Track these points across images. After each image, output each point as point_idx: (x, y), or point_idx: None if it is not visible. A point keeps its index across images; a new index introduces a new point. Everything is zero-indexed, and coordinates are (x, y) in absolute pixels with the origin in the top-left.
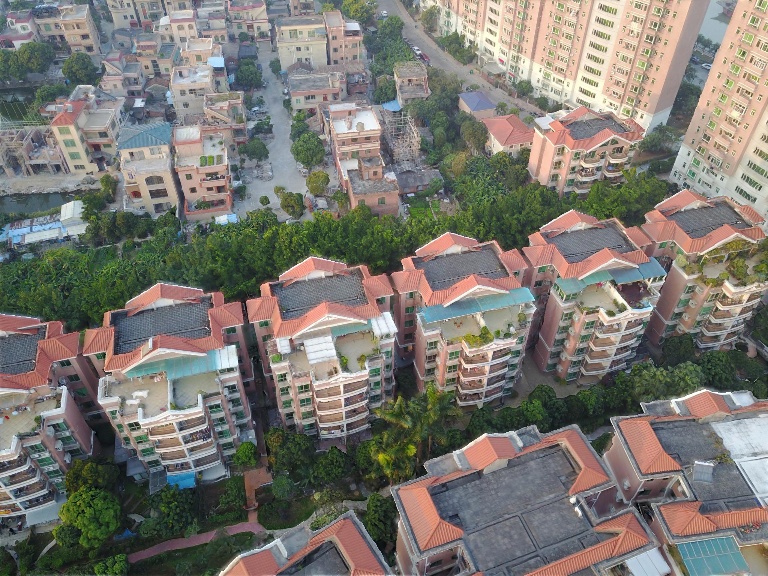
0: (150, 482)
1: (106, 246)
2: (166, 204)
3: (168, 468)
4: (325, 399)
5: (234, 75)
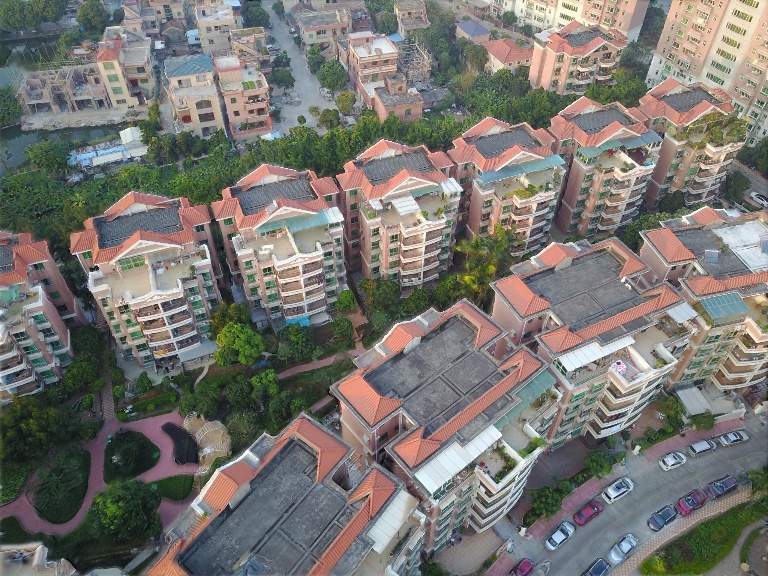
0: (273, 325)
1: (167, 165)
2: (212, 128)
3: (286, 313)
4: (411, 246)
5: (242, 17)
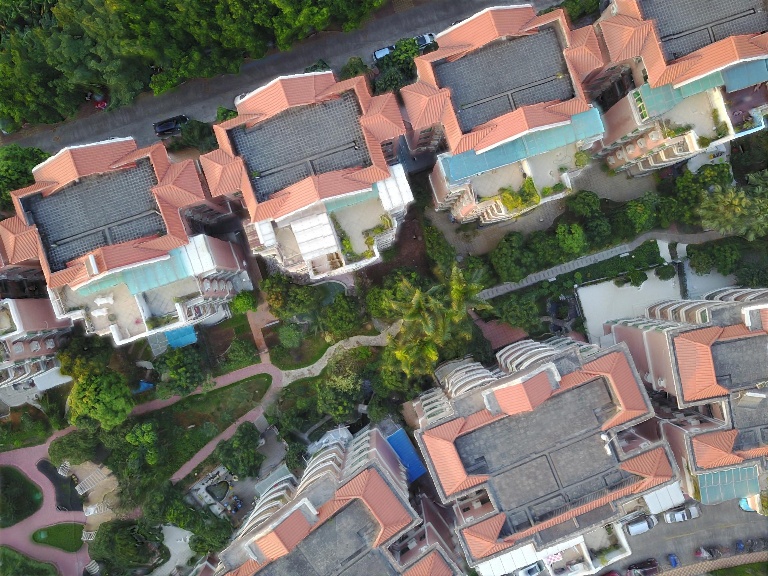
0: (148, 339)
1: None
2: None
3: None
4: None
5: None
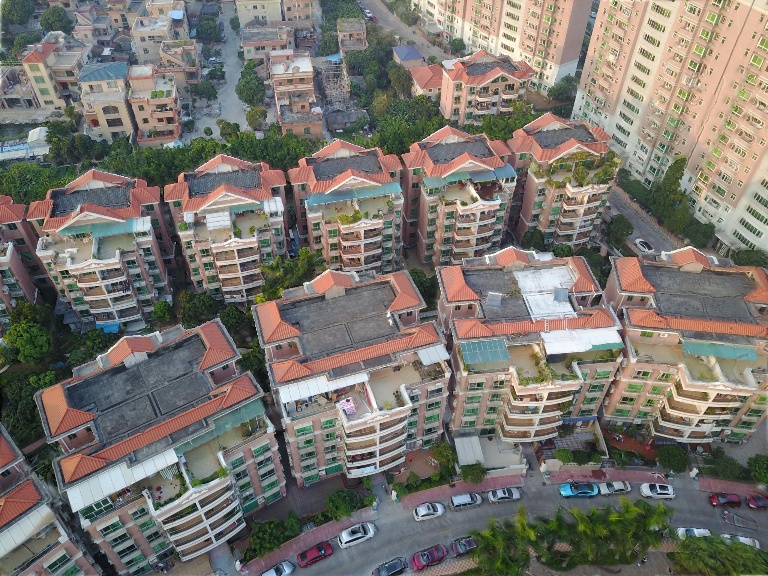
0: (82, 328)
1: (67, 165)
2: (122, 133)
3: (97, 318)
4: (223, 262)
5: (196, 30)
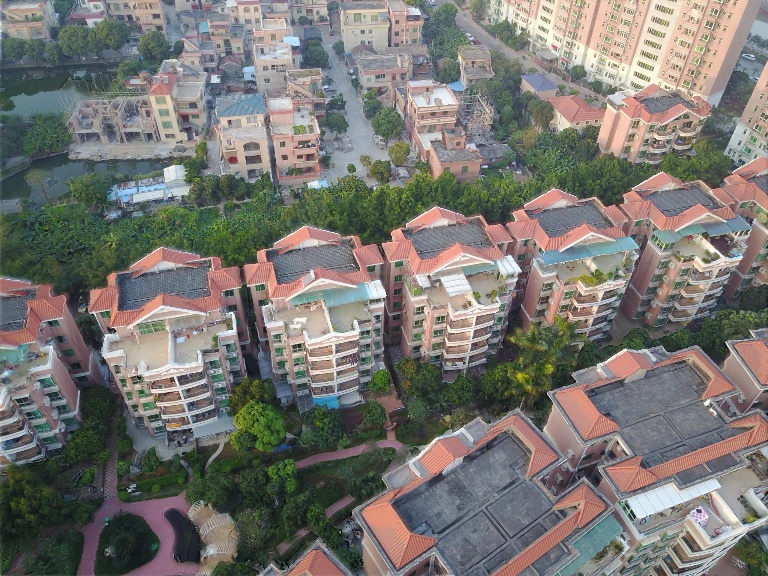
0: (298, 403)
1: (208, 207)
2: (259, 170)
3: (314, 391)
4: (458, 330)
5: (301, 55)
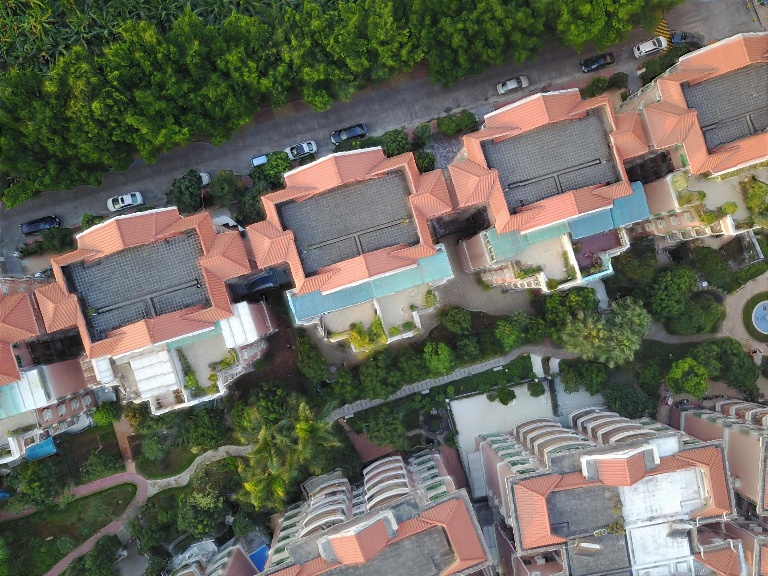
0: None
1: None
2: None
3: None
4: None
5: None
